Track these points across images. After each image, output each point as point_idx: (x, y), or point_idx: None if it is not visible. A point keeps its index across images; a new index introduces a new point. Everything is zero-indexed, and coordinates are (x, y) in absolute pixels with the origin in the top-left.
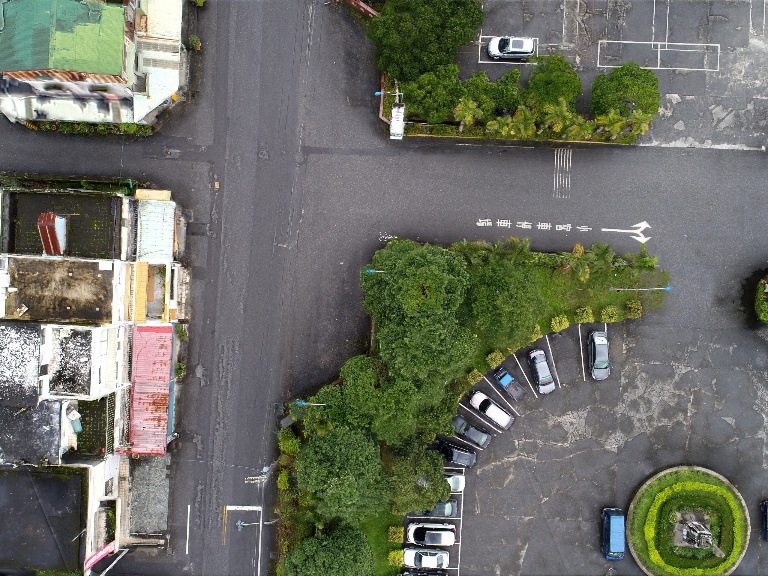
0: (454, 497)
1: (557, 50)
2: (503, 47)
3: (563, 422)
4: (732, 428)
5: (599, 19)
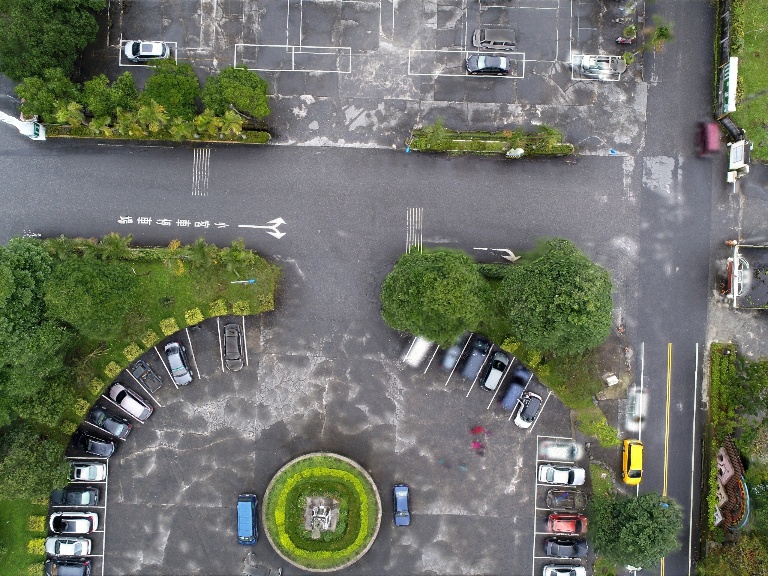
0: (98, 486)
1: (195, 53)
2: (136, 51)
3: (203, 412)
4: (366, 416)
5: (235, 23)
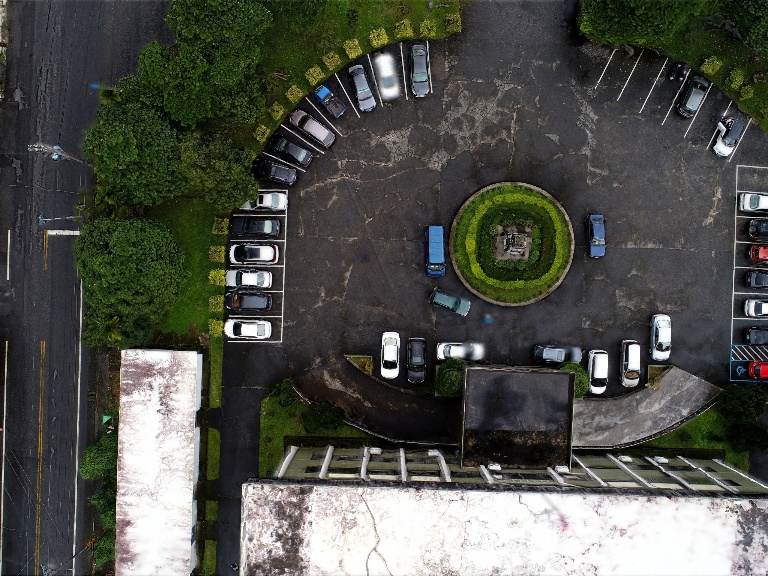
0: None
1: None
2: None
3: (386, 141)
4: (556, 145)
5: None
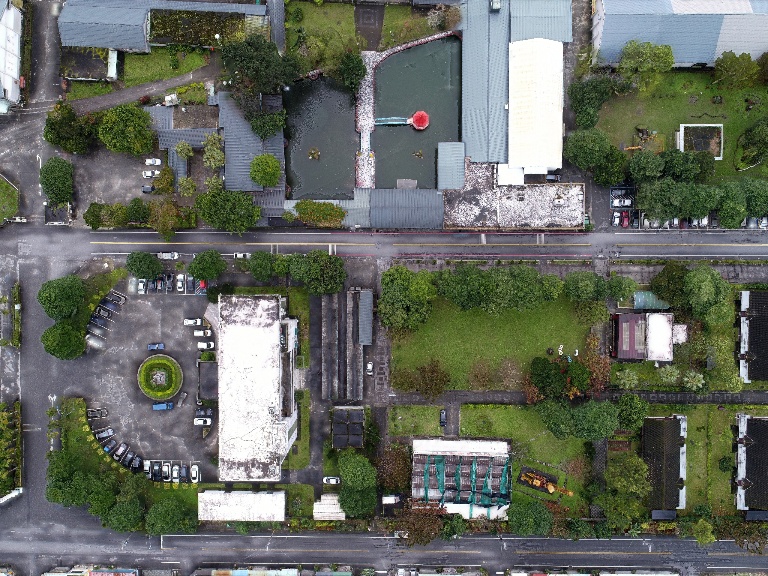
0: None
1: None
2: None
3: (124, 424)
4: (123, 361)
5: None
